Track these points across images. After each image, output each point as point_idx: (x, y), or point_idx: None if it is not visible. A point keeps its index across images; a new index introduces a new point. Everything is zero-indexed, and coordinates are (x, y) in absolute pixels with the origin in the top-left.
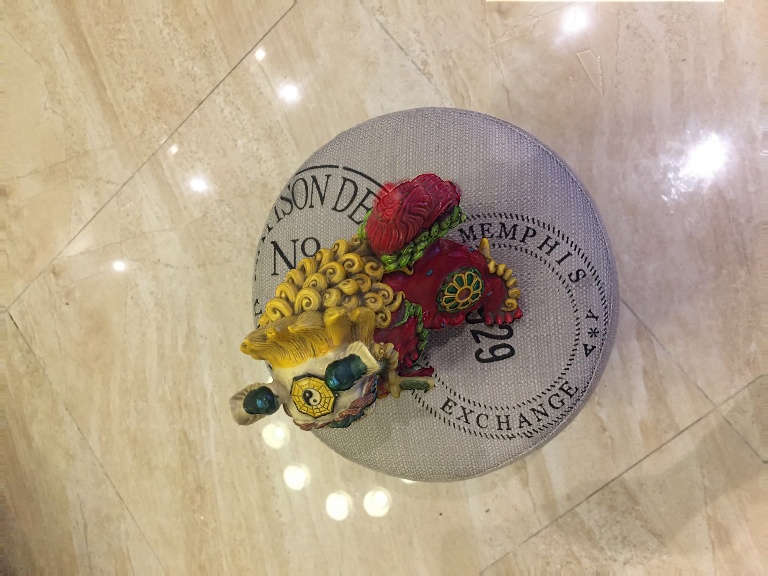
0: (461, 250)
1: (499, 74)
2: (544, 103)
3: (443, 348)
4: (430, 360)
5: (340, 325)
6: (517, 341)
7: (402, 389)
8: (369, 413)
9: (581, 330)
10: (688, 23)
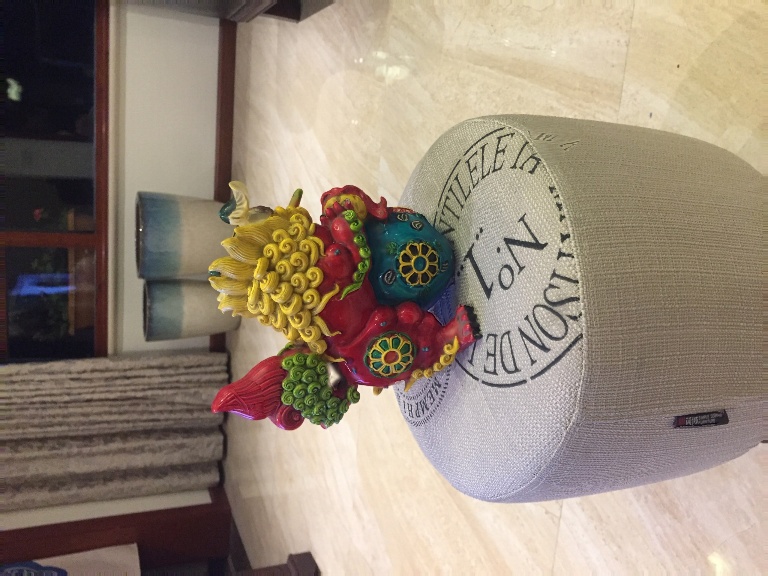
0: None
1: None
2: None
3: None
4: None
5: None
6: None
7: None
8: None
9: None
10: None
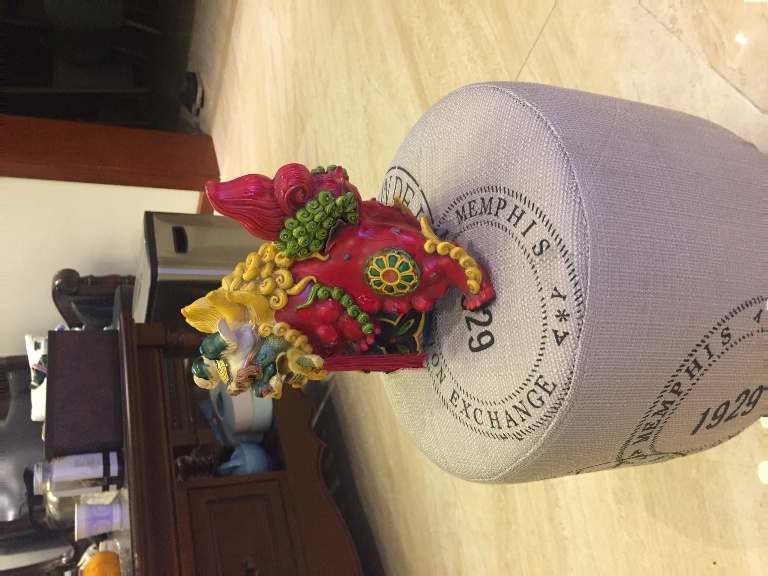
0: (389, 232)
1: (757, 3)
2: None
3: (449, 337)
4: (442, 349)
5: (225, 306)
6: (495, 327)
7: (301, 366)
8: (274, 385)
9: (548, 313)
10: None
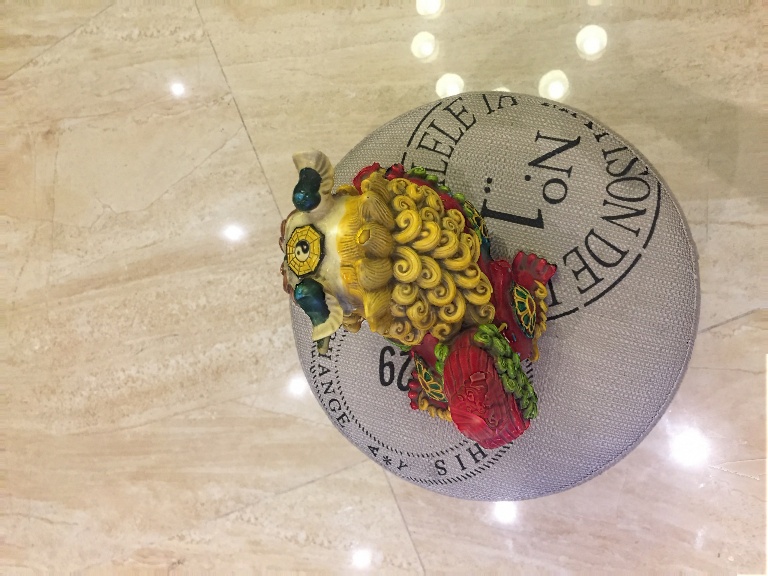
0: None
1: None
2: (726, 407)
3: None
4: None
5: None
6: (393, 392)
7: None
8: None
9: (391, 452)
10: (760, 574)
